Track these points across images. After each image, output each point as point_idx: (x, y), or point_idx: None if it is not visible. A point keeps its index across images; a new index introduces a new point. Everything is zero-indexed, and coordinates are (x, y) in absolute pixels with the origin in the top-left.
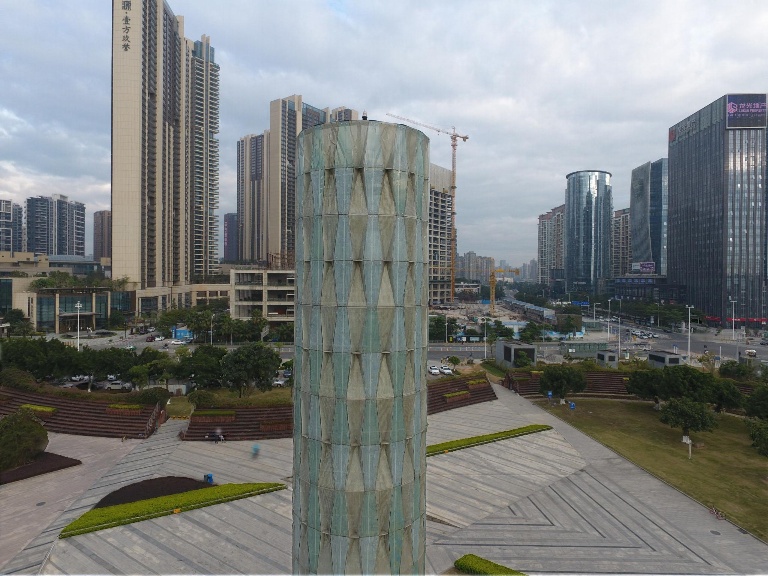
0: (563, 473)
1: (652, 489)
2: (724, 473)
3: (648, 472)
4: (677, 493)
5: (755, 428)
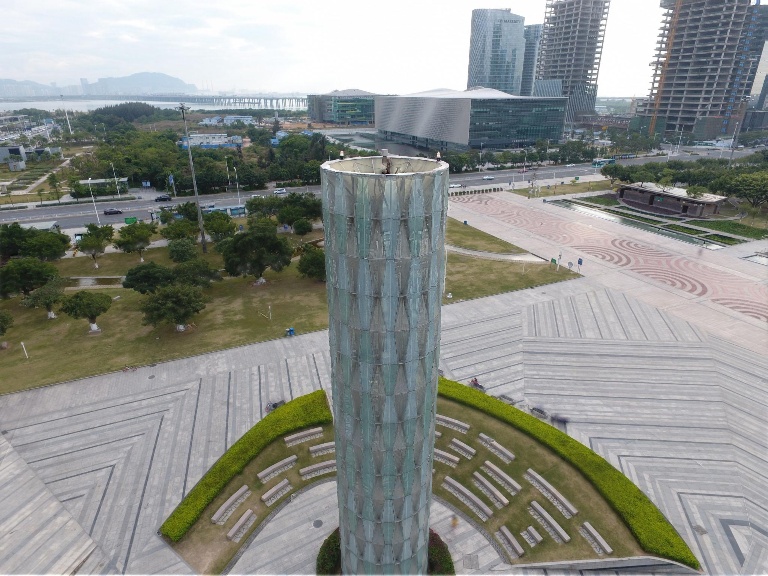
0: (4, 448)
1: (73, 392)
2: (67, 349)
3: (39, 388)
4: (87, 380)
5: (64, 302)
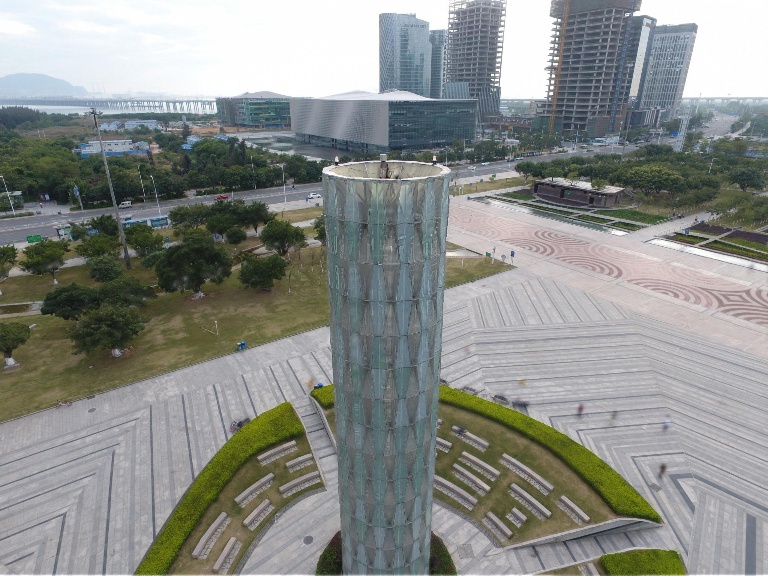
0: None
1: None
2: None
3: None
4: (12, 423)
5: None
